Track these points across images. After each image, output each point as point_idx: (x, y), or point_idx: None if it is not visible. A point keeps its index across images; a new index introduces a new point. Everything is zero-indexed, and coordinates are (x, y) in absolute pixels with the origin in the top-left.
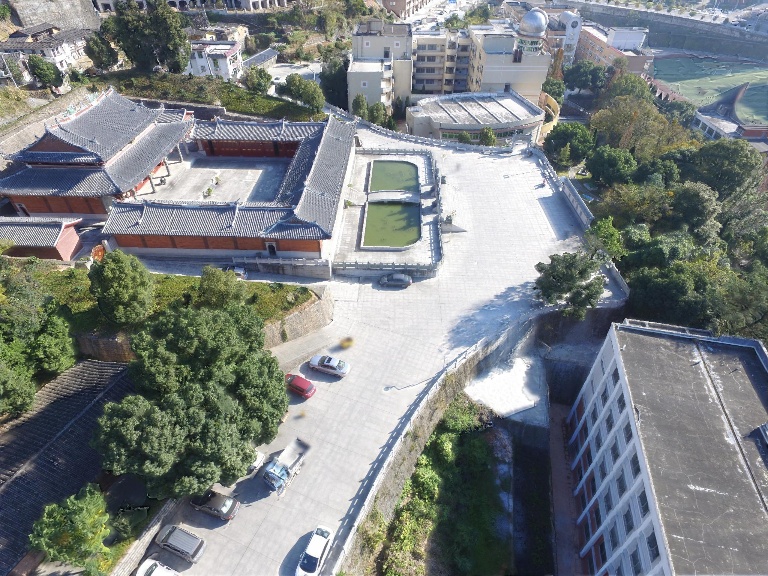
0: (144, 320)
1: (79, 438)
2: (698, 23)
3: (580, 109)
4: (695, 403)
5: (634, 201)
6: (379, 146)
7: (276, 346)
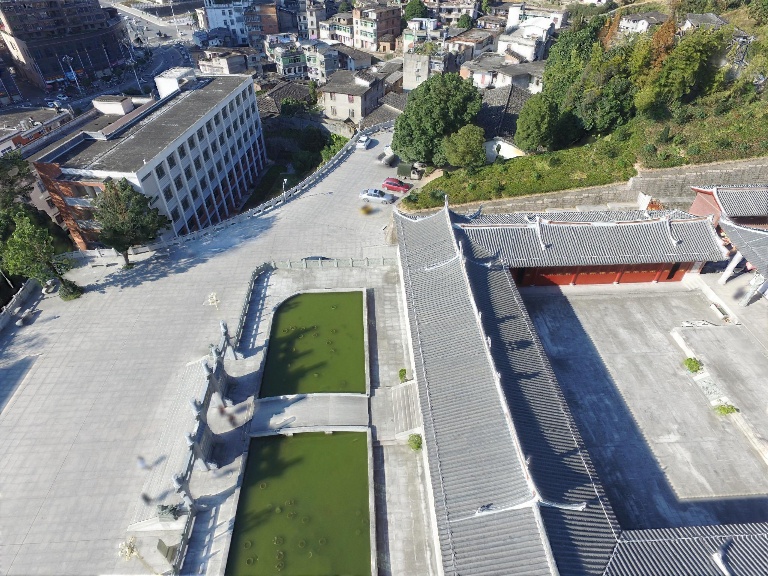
0: (521, 156)
1: None
2: None
3: None
4: (131, 147)
5: None
6: None
7: None
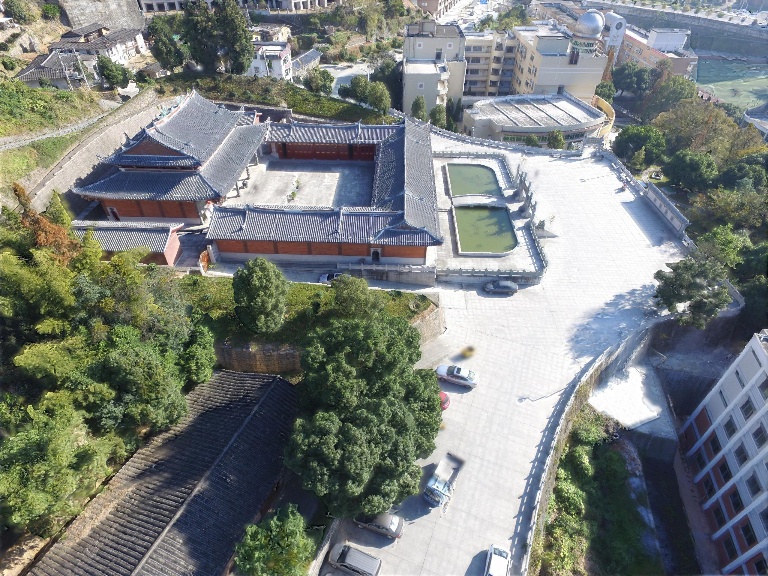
0: None
1: (245, 453)
2: (726, 25)
3: (623, 111)
4: None
5: (731, 207)
6: (446, 149)
7: None
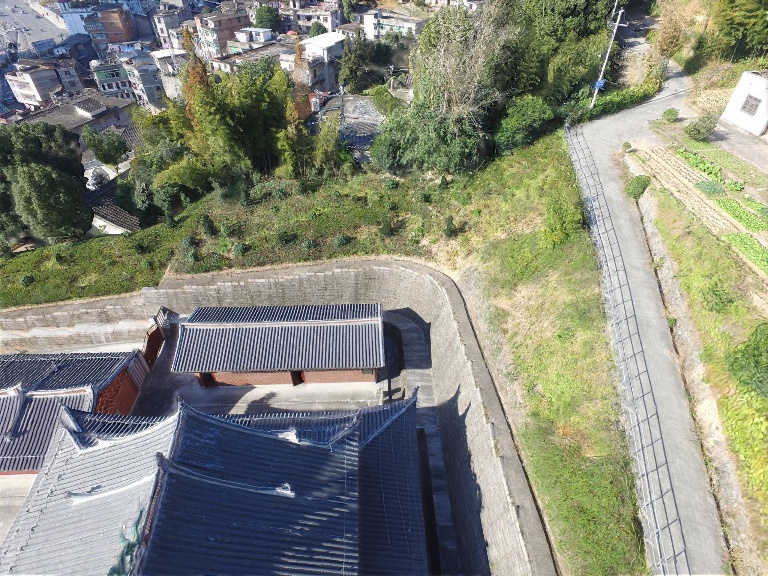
0: None
1: None
2: None
3: None
4: None
5: None
6: None
7: None
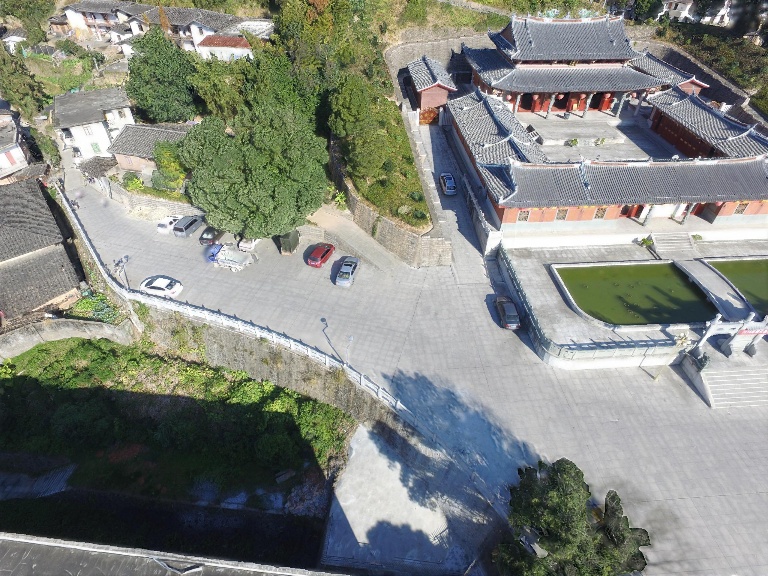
0: (348, 142)
1: None
2: None
3: None
4: None
5: None
6: None
7: (366, 232)
